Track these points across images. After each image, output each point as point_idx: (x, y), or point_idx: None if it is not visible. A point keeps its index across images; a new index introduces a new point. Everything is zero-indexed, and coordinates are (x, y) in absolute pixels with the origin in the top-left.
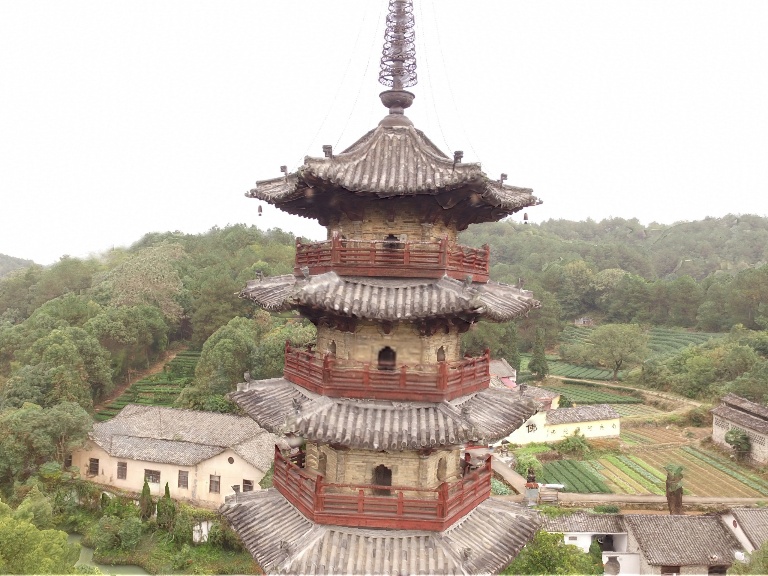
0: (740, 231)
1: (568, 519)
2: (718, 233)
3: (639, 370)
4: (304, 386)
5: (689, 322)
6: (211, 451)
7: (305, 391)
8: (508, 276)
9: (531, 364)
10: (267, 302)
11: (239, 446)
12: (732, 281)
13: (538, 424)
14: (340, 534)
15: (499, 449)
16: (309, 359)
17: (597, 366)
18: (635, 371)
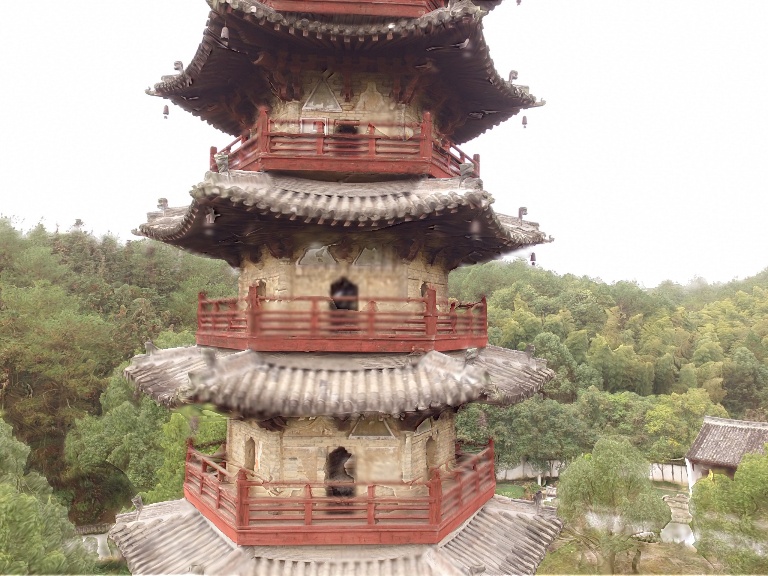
0: None
1: None
2: None
3: None
4: None
5: None
6: None
7: None
8: None
9: None
10: None
11: None
12: None
13: None
14: None
15: None
16: None
17: None
18: None
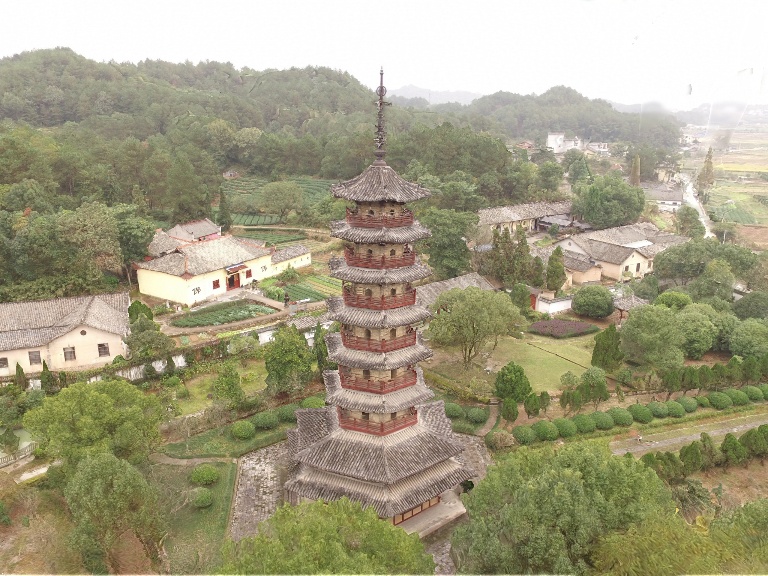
0: (320, 83)
1: (325, 316)
2: (304, 84)
3: (294, 214)
4: (367, 267)
5: (313, 171)
6: (53, 331)
7: (363, 269)
8: (158, 135)
9: (219, 219)
10: (356, 239)
11: (86, 321)
12: (345, 142)
13: (267, 265)
14: (387, 312)
15: (247, 287)
16: (370, 257)
17: (259, 213)
18: (292, 215)
